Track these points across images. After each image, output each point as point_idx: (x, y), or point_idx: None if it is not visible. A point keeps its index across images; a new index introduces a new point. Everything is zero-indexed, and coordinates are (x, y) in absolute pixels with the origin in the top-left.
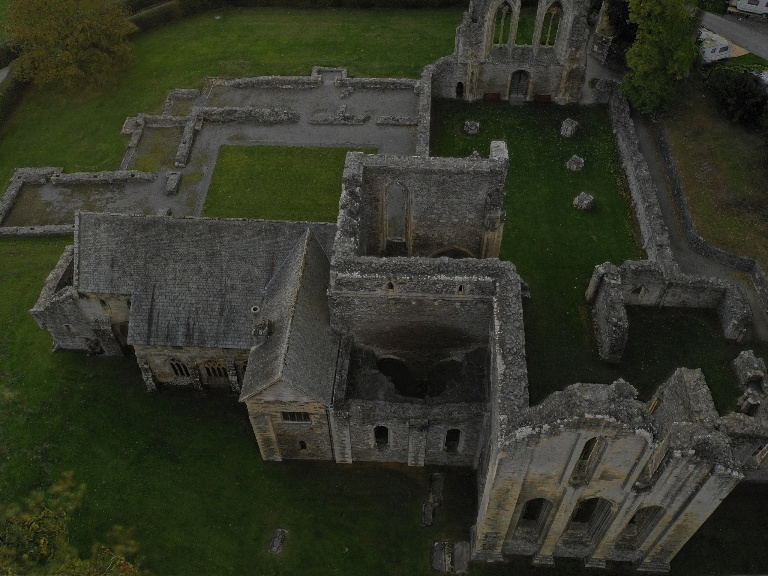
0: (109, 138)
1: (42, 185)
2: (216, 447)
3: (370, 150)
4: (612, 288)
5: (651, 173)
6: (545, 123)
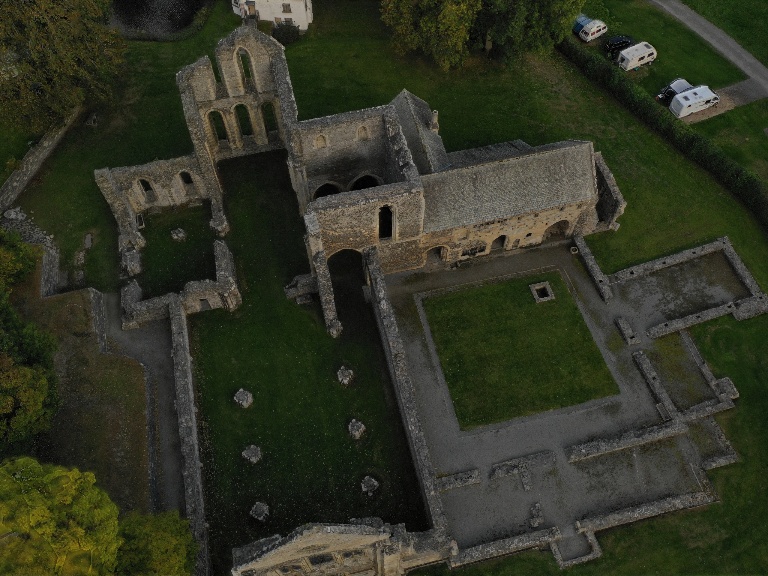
0: (734, 368)
1: (737, 300)
2: (451, 151)
3: (468, 425)
4: (223, 269)
5: (173, 463)
6: (288, 522)
